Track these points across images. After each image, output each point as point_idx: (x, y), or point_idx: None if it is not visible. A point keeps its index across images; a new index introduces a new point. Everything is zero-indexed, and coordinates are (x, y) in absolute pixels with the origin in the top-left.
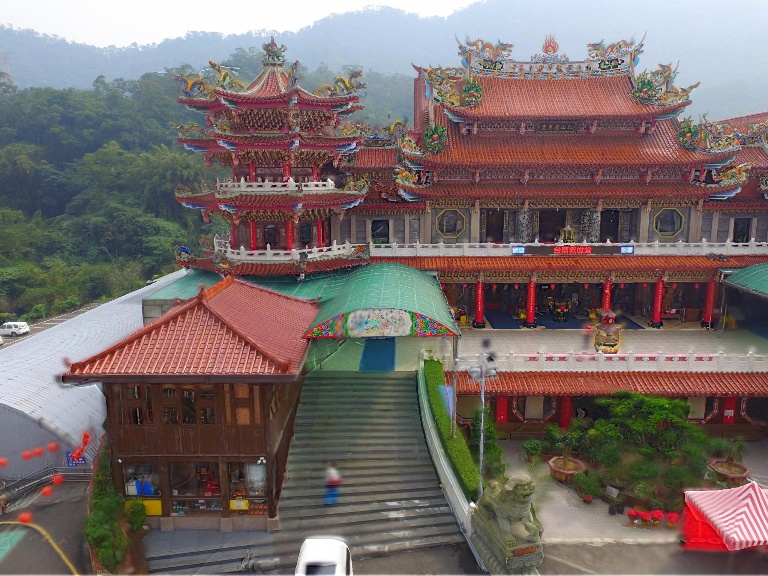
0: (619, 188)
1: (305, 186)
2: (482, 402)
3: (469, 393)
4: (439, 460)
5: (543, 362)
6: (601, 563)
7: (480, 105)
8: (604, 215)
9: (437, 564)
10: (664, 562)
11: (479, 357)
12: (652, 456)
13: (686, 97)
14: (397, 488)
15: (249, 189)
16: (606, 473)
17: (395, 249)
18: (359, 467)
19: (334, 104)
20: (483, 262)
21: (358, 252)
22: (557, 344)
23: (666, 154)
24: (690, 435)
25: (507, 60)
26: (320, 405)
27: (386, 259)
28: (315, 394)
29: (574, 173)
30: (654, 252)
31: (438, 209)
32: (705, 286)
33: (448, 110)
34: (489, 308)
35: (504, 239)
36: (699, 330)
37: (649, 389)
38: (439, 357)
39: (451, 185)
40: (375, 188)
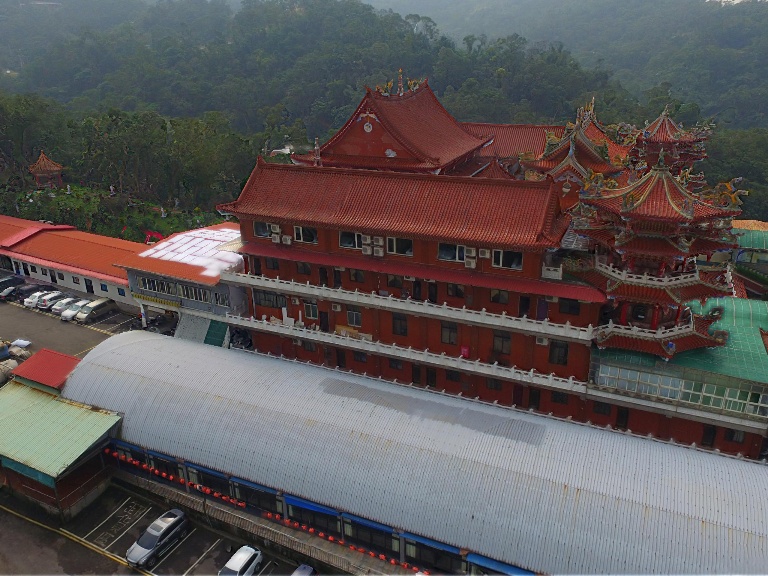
0: None
1: None
2: None
3: None
4: None
5: None
6: None
7: None
8: None
9: None
10: None
11: None
12: None
13: None
14: None
15: None
16: None
17: None
18: None
19: None
20: None
21: None
22: None
23: None
24: None
25: None
26: None
27: None
28: None
29: None
30: None
31: None
32: None
33: None
34: None
35: None
36: None
37: None
38: None
39: None
40: None
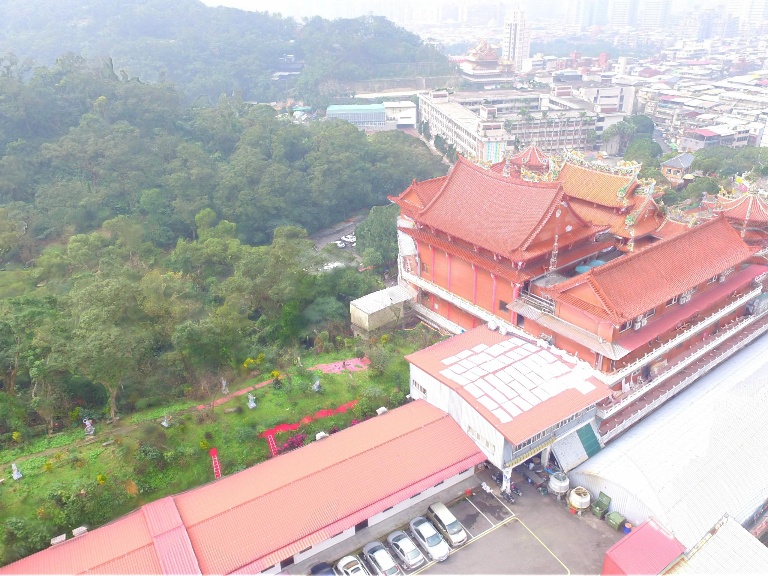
0: None
1: None
2: None
3: None
4: None
5: None
6: None
7: None
8: None
9: None
10: None
11: None
12: None
13: None
14: None
15: None
16: None
17: None
18: None
19: None
20: None
21: None
22: None
23: None
24: None
25: None
26: None
27: None
28: None
29: None
30: None
31: None
32: None
33: None
34: None
35: None
36: None
37: None
38: None
39: None
40: None
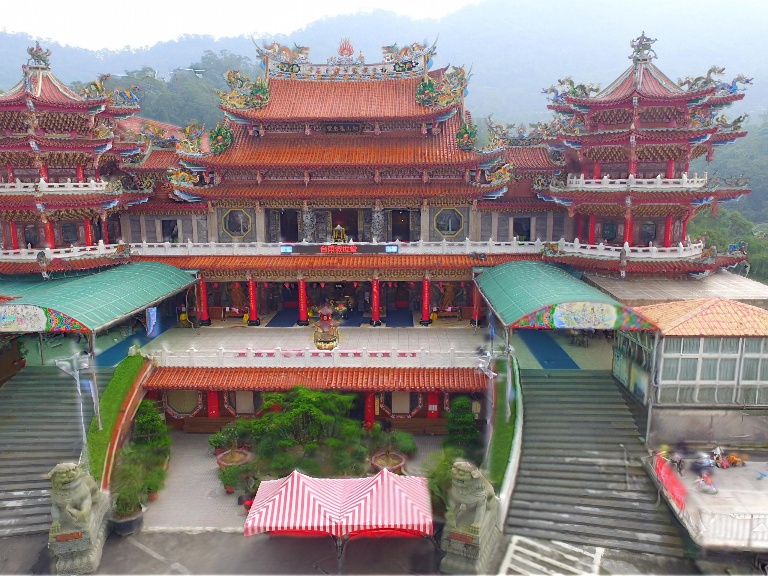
0: (395, 188)
1: (61, 187)
2: (194, 397)
3: (166, 388)
4: (81, 452)
5: (251, 358)
6: (178, 550)
7: (267, 107)
8: (394, 215)
9: (19, 550)
10: (239, 549)
11: (190, 353)
12: (292, 448)
13: (456, 99)
14: (33, 478)
15: (2, 190)
16: (255, 465)
17: (167, 248)
18: (10, 458)
19: (86, 107)
20: (248, 261)
21: (119, 251)
22: (306, 341)
23: (442, 155)
24: (341, 428)
25: (304, 63)
26: (13, 399)
27: (157, 258)
28: (15, 389)
29: (356, 174)
30: (419, 251)
31: (224, 209)
32: (472, 284)
33: (228, 112)
34: (287, 306)
35: (299, 239)
36: (465, 328)
37: (341, 384)
38: (151, 353)
39: (236, 186)
40: (162, 189)
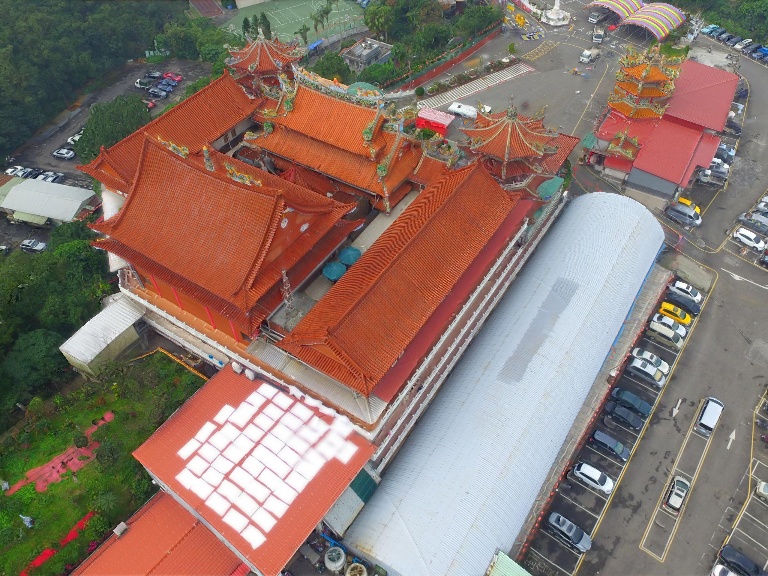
0: None
1: None
2: None
3: None
4: None
5: None
6: None
7: None
8: None
9: None
10: None
11: None
12: None
13: None
14: None
15: None
16: None
17: None
18: None
19: None
20: None
21: None
22: None
23: None
24: None
25: None
26: None
27: None
28: None
29: None
30: None
31: None
32: None
33: None
34: None
35: None
36: None
37: None
38: None
39: None
40: None
